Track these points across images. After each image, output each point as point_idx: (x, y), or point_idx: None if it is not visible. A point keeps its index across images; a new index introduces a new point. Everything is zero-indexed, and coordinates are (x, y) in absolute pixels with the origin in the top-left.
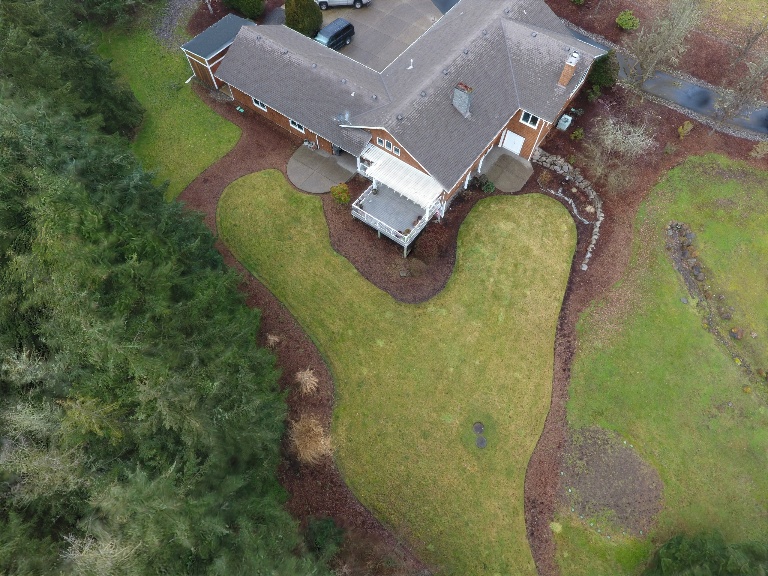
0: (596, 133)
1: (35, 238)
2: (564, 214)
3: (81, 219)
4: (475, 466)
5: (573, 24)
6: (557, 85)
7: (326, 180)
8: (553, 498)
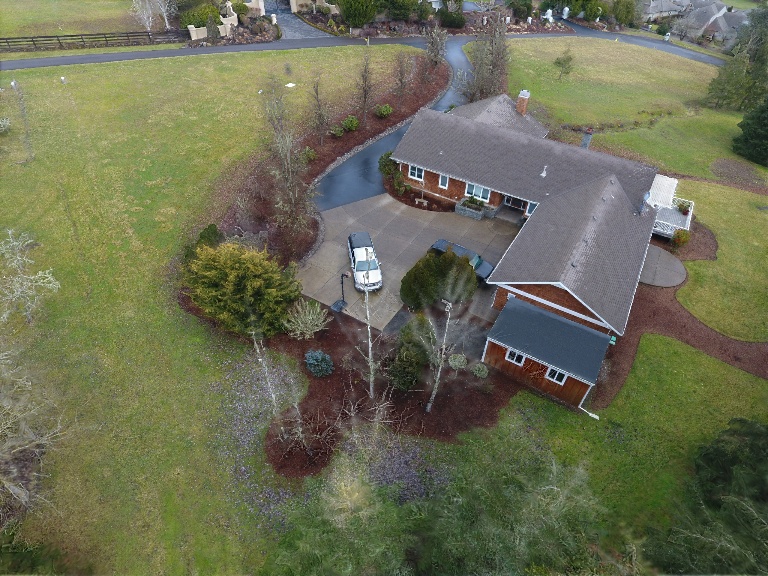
0: None
1: None
2: None
3: None
4: None
5: (375, 137)
6: (524, 117)
7: (662, 257)
8: (766, 188)
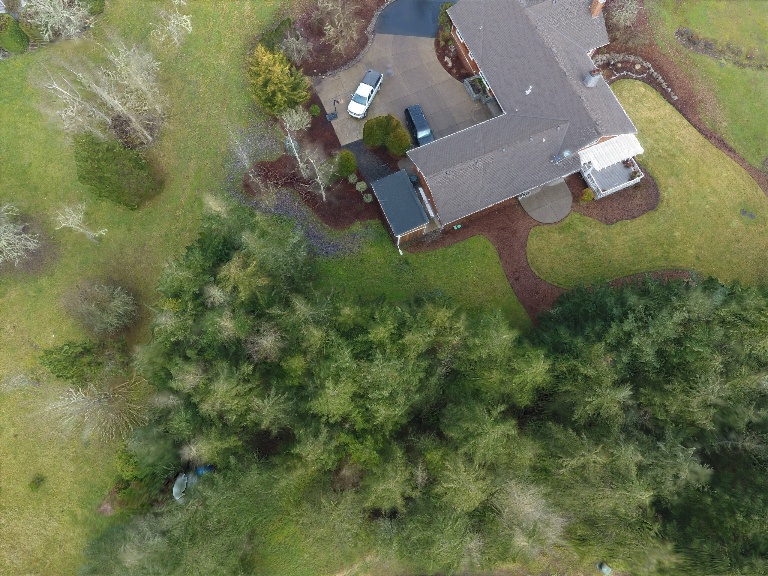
0: (612, 24)
1: (761, 327)
2: (633, 83)
3: (762, 299)
4: (762, 226)
5: None
6: (593, 19)
7: (561, 201)
8: None
